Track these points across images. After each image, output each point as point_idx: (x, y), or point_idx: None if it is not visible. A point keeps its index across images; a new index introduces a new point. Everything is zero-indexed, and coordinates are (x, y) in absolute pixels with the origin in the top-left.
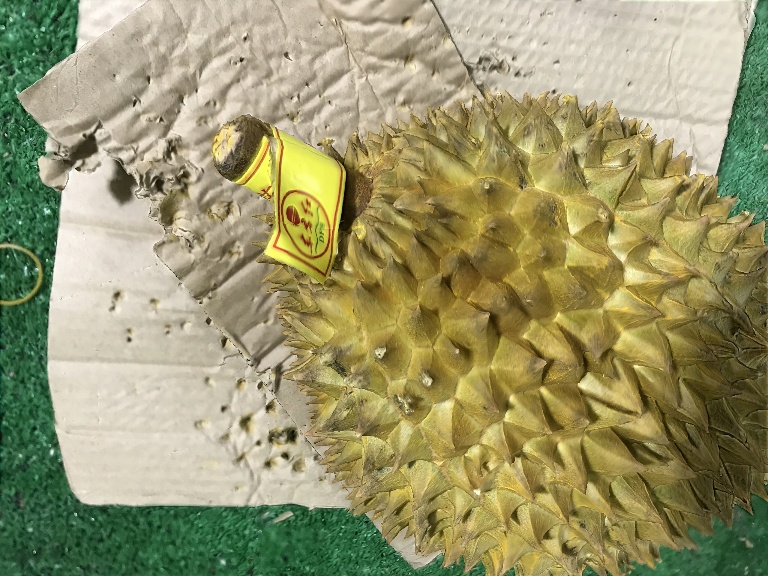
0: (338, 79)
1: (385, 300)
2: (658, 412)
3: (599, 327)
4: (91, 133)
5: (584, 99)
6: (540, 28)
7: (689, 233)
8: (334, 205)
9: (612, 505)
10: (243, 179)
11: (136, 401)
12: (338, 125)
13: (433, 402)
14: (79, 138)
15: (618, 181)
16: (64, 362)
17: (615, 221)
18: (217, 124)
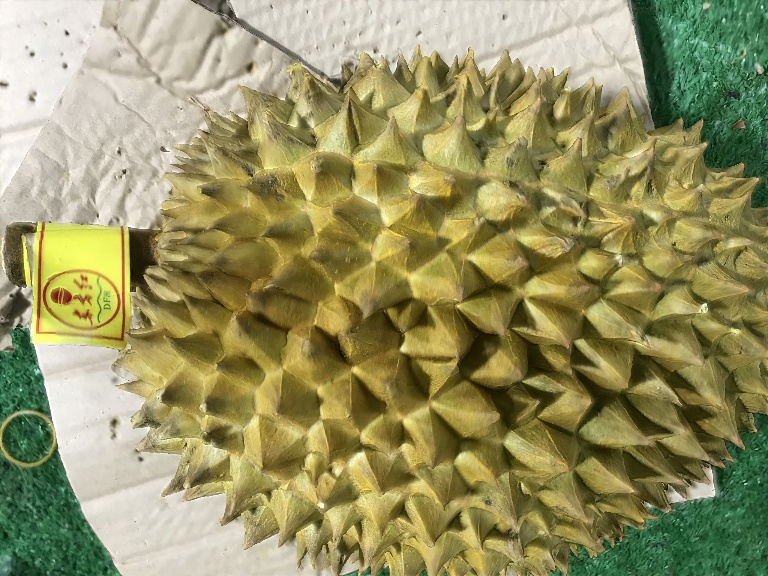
0: None
1: (165, 342)
2: (513, 346)
3: (368, 282)
4: (17, 291)
5: None
6: (385, 11)
7: (451, 141)
8: (119, 270)
9: (516, 468)
10: (27, 281)
11: (171, 514)
12: None
13: (240, 426)
14: (7, 300)
15: (339, 124)
16: (94, 500)
17: (354, 166)
18: None
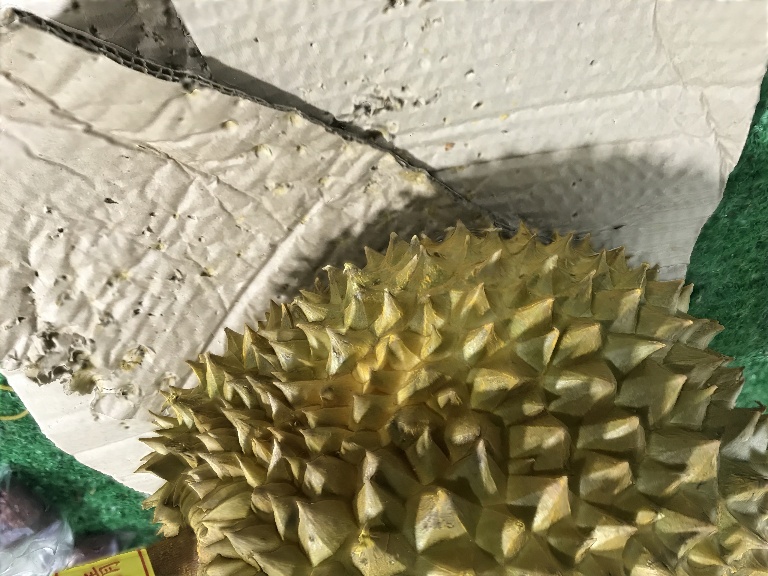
0: (185, 193)
1: None
2: None
3: None
4: None
5: (526, 99)
6: (428, 44)
7: None
8: None
9: None
10: None
11: None
12: (212, 233)
13: None
14: None
15: None
16: (86, 451)
17: None
18: (79, 292)
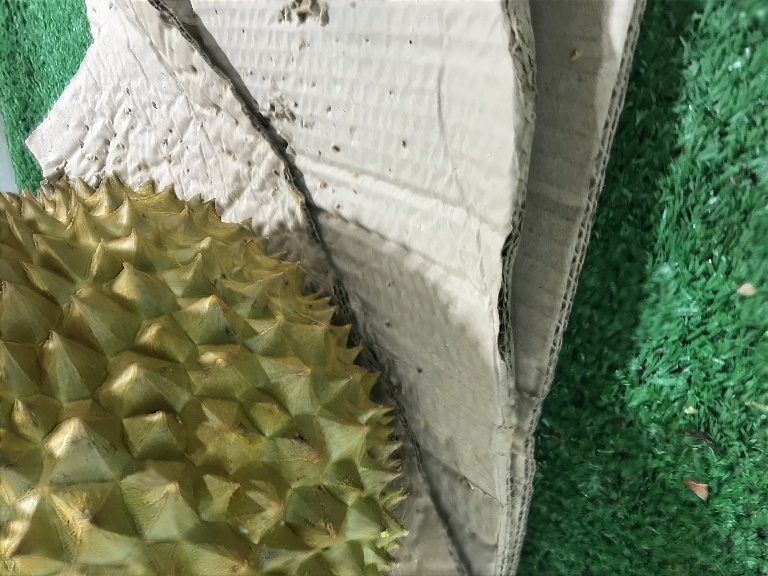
0: (188, 126)
1: None
2: None
3: None
4: (63, 167)
5: (364, 161)
6: (304, 65)
7: None
8: None
9: None
10: None
11: None
12: (193, 170)
13: None
14: (54, 170)
15: None
16: None
17: None
18: (126, 163)
